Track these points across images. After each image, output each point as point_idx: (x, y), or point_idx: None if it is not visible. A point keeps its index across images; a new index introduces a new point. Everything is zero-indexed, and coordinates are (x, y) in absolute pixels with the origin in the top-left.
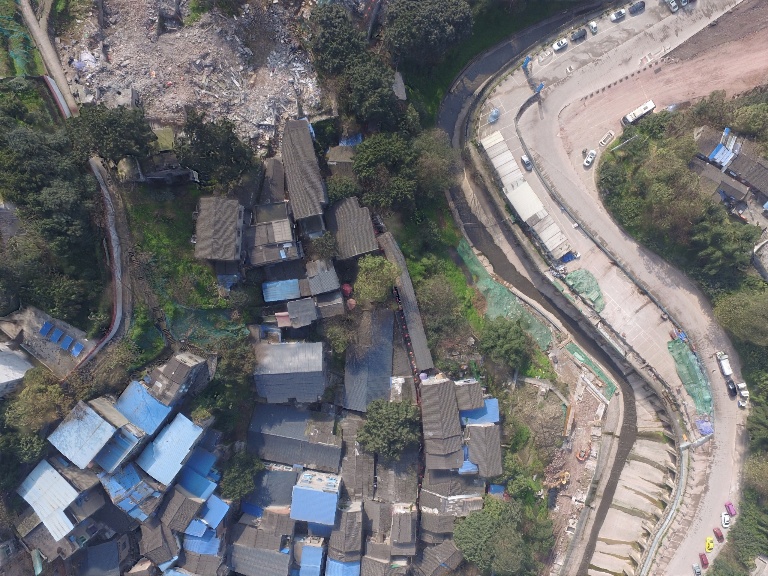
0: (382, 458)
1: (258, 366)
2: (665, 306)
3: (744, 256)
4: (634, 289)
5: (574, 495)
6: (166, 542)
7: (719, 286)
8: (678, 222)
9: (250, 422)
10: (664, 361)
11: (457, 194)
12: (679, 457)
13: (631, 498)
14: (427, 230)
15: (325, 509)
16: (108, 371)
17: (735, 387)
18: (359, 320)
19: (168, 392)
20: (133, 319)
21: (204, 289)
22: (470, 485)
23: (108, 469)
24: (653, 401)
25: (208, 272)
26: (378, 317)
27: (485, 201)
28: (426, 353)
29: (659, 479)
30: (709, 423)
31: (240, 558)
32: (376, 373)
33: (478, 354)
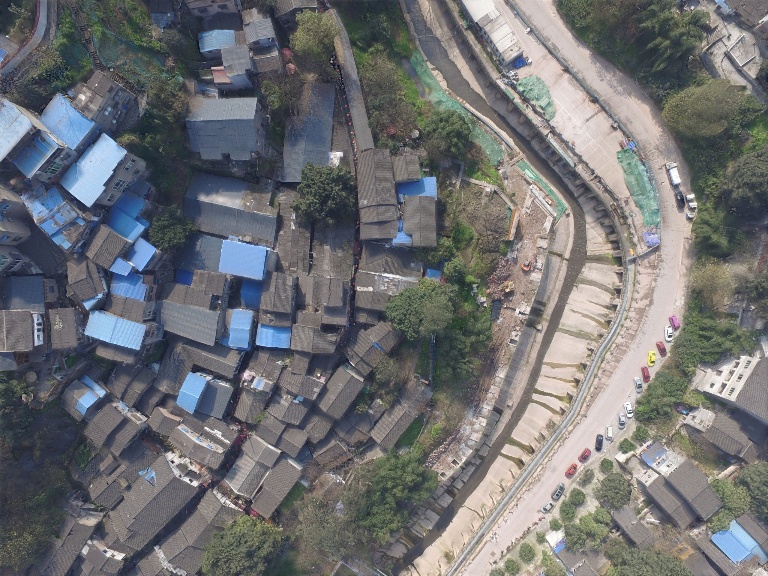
0: (318, 234)
1: (191, 114)
2: (616, 115)
3: (691, 42)
4: (585, 97)
5: (518, 307)
6: (91, 278)
7: (669, 86)
8: (627, 12)
9: (187, 190)
10: (613, 172)
11: (413, 7)
12: (625, 271)
13: (578, 321)
14: (375, 19)
15: (254, 263)
16: (32, 82)
17: (683, 198)
18: (299, 93)
19: (91, 105)
20: (58, 30)
21: (136, 25)
22: (407, 267)
23: (27, 174)
24: (603, 222)
25: (142, 11)
26: (318, 89)
27: (440, 13)
28: (367, 132)
29: (606, 301)
30: (656, 235)
31: (169, 315)
32: (314, 144)
33: (423, 150)
